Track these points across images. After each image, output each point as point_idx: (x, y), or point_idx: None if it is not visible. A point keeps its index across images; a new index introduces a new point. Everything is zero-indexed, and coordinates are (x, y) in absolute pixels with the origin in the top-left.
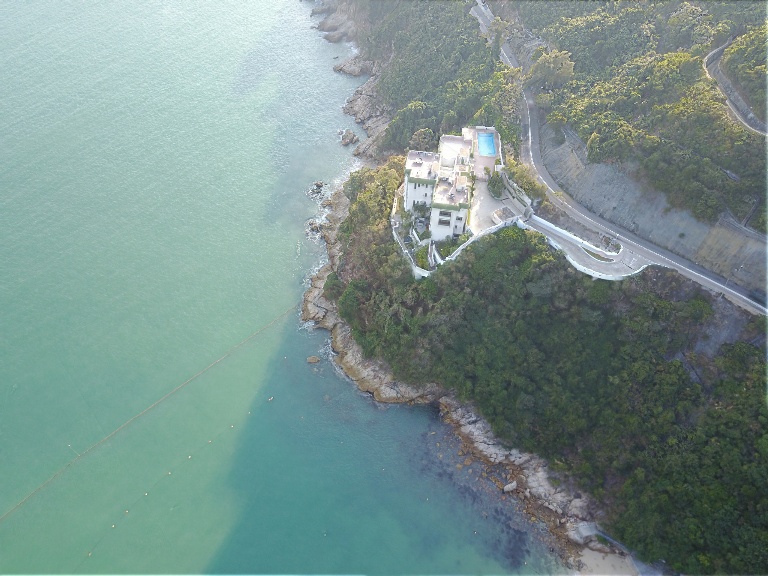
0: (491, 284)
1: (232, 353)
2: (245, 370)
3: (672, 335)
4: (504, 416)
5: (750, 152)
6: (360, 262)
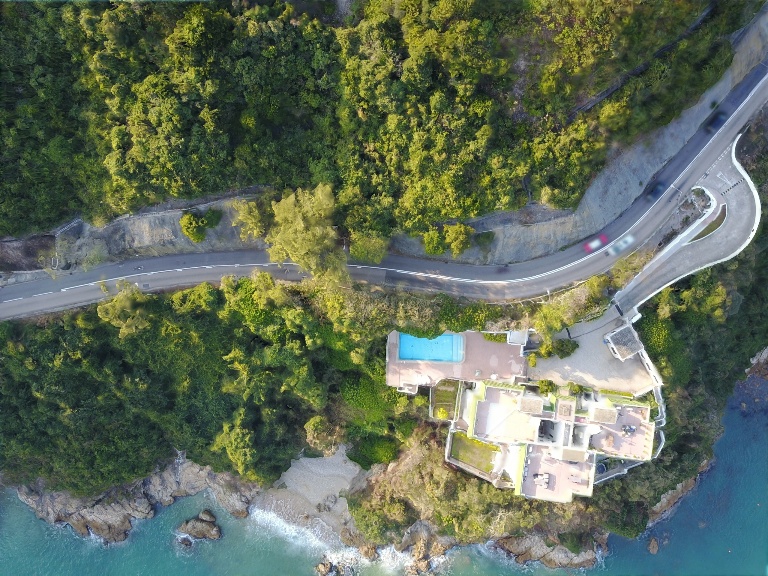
0: None
1: None
2: None
3: None
4: None
5: None
6: None
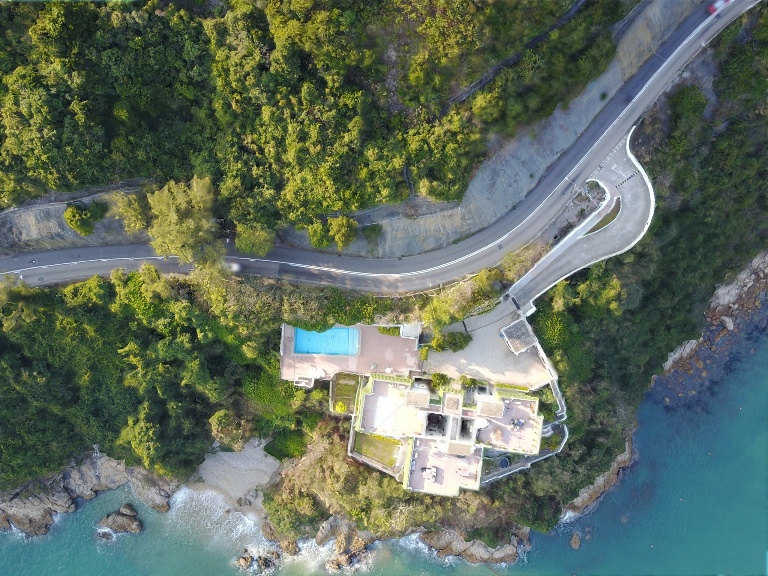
0: None
1: None
2: None
3: None
4: (689, 332)
5: None
6: None
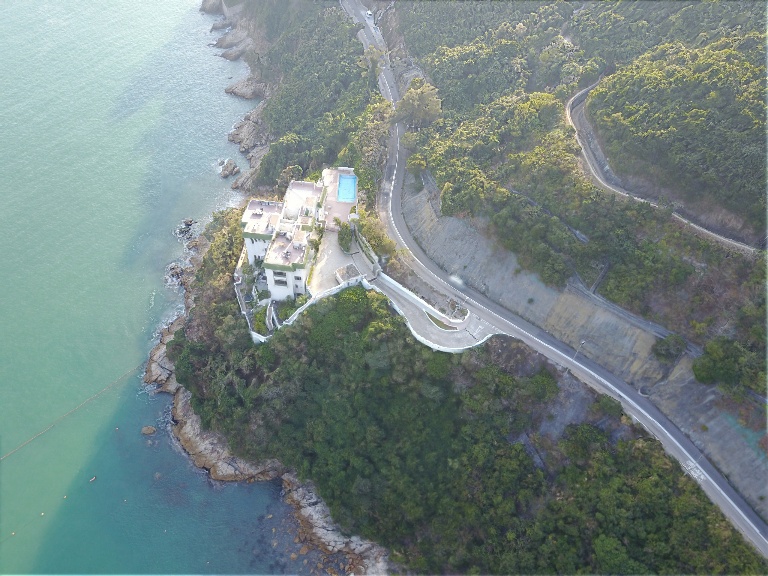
0: (331, 352)
1: (57, 424)
2: (70, 444)
3: (515, 414)
4: (341, 501)
5: (598, 212)
6: (201, 321)
